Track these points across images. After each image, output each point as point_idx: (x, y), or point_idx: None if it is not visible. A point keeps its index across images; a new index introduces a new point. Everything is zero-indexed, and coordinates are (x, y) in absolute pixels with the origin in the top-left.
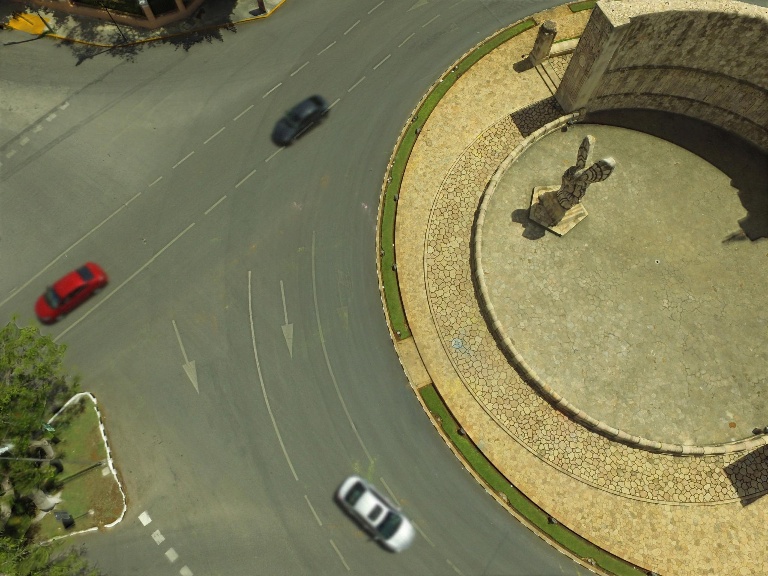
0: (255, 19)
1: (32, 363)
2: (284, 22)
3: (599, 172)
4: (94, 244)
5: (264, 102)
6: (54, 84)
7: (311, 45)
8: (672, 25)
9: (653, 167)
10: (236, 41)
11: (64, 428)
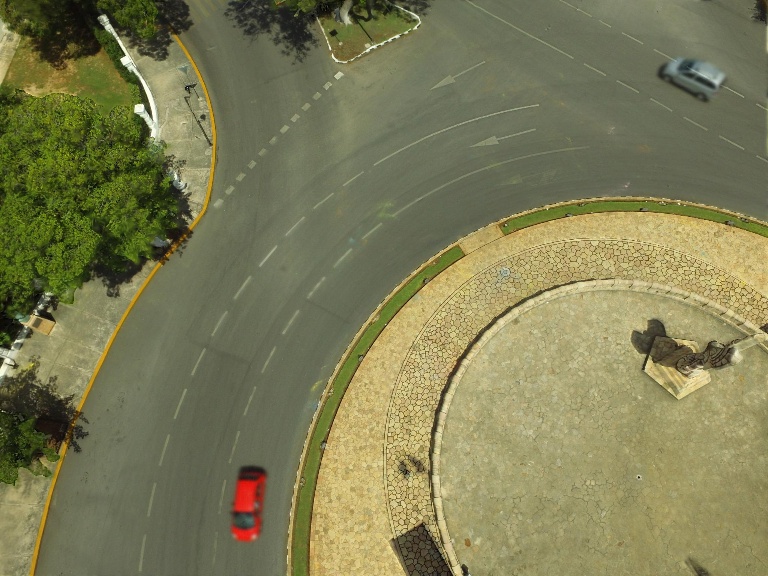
0: None
1: None
2: None
3: (723, 356)
4: None
5: (716, 87)
6: None
7: None
8: None
9: (767, 483)
10: None
11: (394, 15)
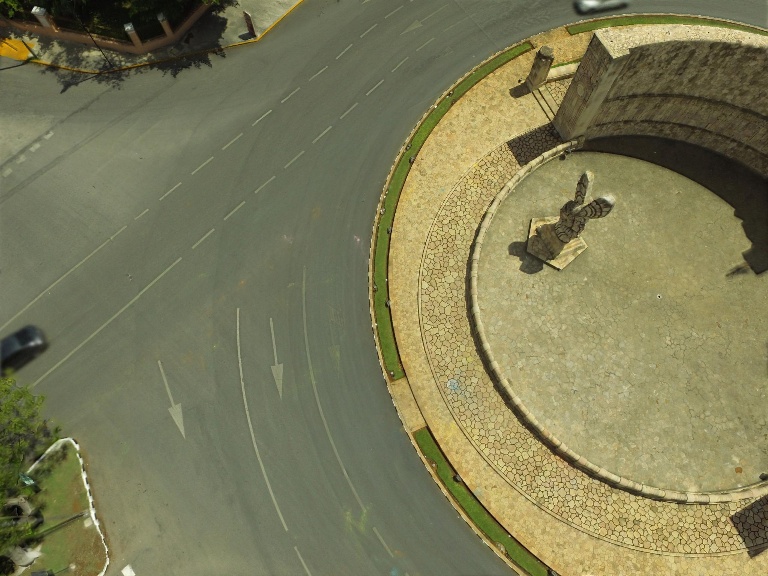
0: (245, 43)
1: (7, 418)
2: (274, 46)
3: (598, 209)
4: (78, 281)
5: (254, 130)
6: (38, 113)
7: (302, 70)
8: (673, 55)
9: (654, 197)
10: (225, 66)
11: (45, 476)
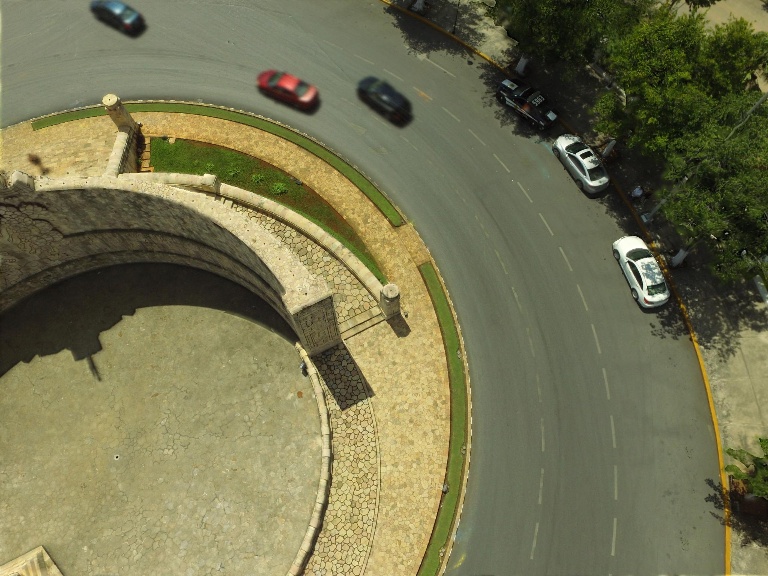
0: None
1: None
2: None
3: None
4: None
5: None
6: None
7: None
8: None
9: None
10: None
11: None
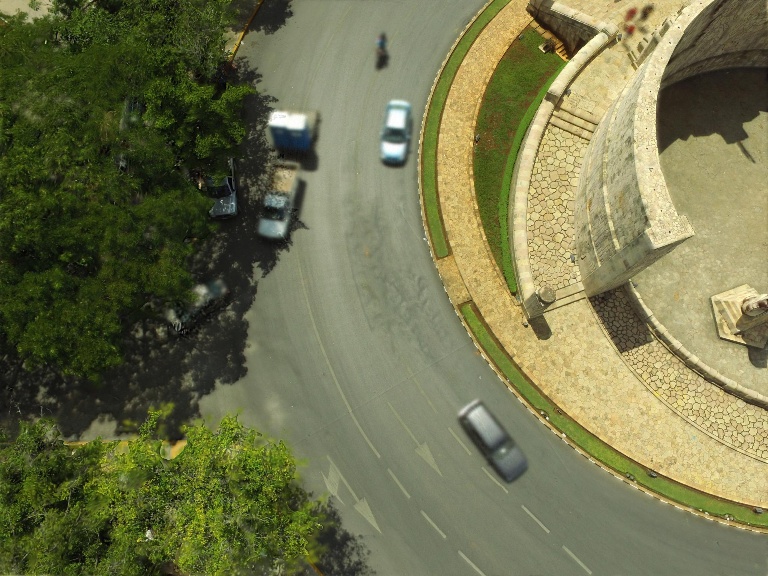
0: None
1: None
2: None
3: None
4: None
5: None
6: None
7: None
8: None
9: None
10: None
11: None
